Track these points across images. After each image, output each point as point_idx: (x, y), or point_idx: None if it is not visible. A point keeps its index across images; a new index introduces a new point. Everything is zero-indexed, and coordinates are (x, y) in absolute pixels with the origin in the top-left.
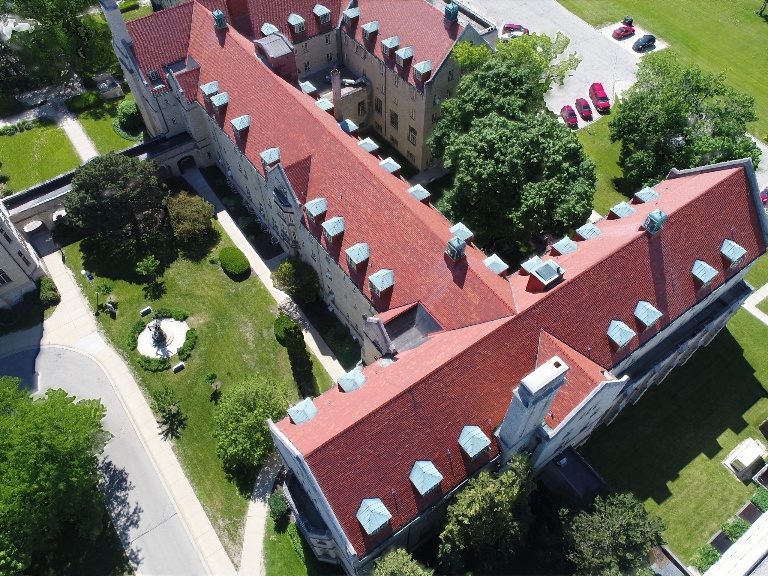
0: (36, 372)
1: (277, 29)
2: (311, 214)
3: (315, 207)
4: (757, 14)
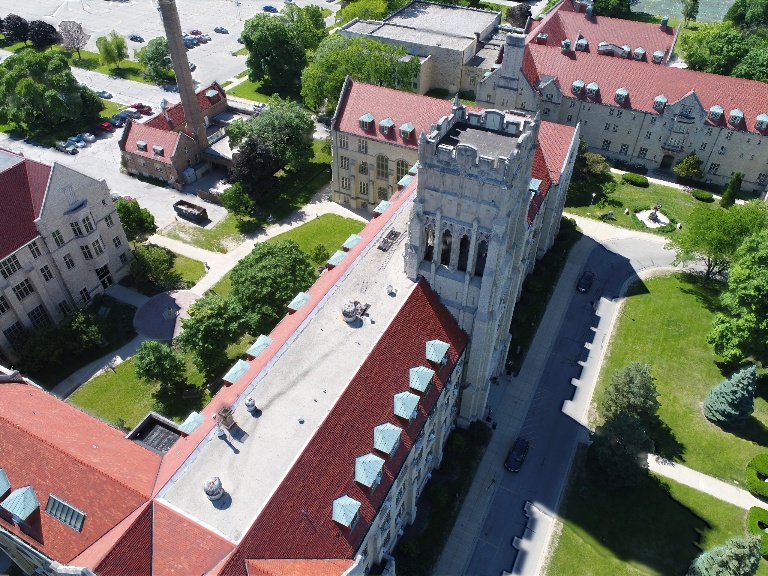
0: (616, 253)
1: None
2: (717, 114)
3: (719, 109)
4: (684, 28)
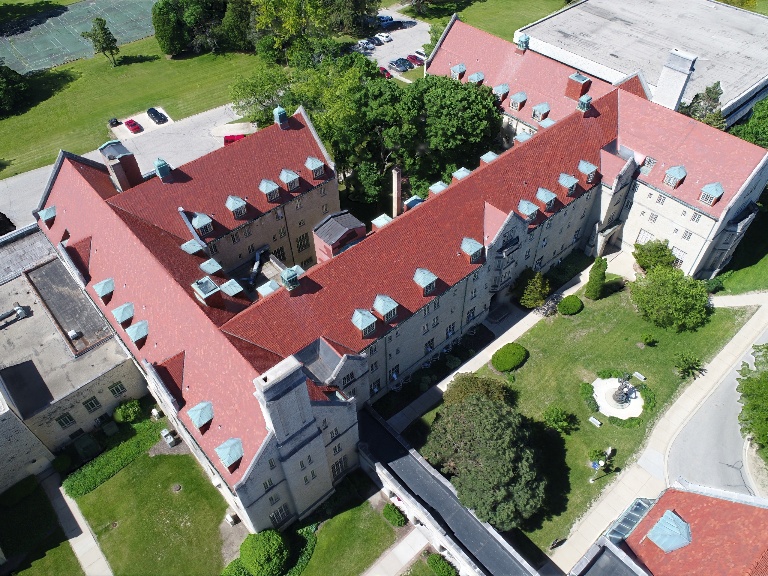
0: None
1: (232, 280)
2: None
3: (532, 206)
4: (116, 67)
